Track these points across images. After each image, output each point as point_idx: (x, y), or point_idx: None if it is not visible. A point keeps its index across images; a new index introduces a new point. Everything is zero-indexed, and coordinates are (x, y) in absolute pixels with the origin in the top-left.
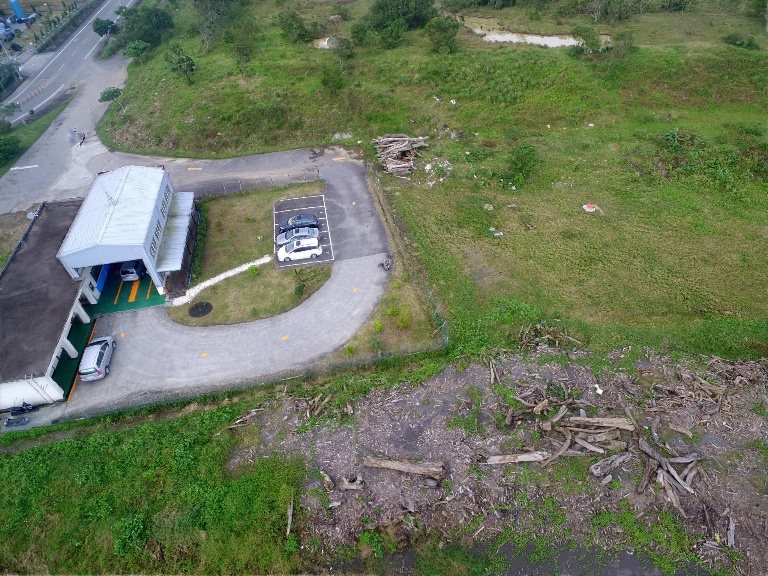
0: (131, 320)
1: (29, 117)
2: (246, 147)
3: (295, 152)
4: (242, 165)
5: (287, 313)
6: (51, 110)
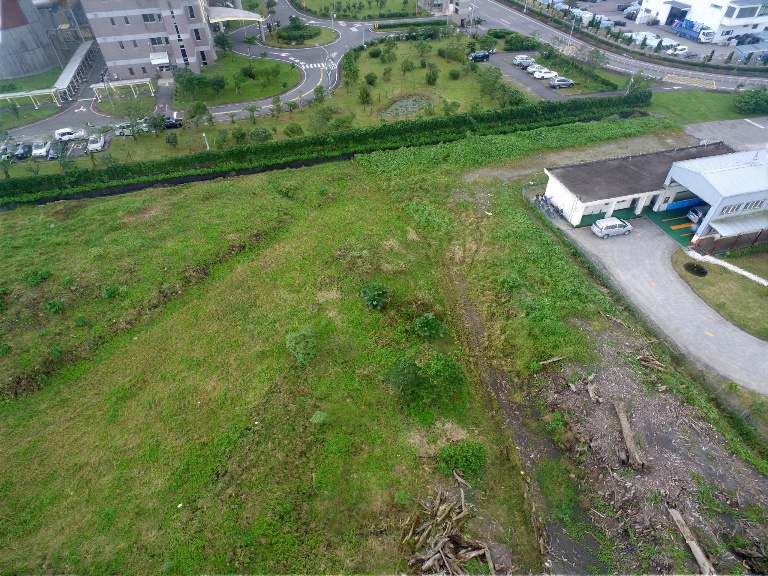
0: (655, 234)
1: None
2: None
3: None
4: None
5: (740, 330)
6: None
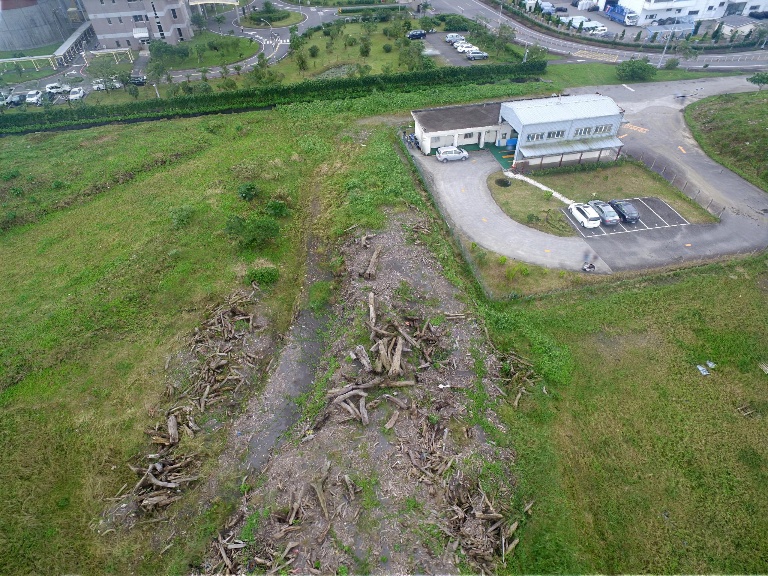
0: (487, 161)
1: (701, 69)
2: (745, 166)
3: (767, 198)
4: (710, 171)
5: (509, 218)
6: (721, 72)
